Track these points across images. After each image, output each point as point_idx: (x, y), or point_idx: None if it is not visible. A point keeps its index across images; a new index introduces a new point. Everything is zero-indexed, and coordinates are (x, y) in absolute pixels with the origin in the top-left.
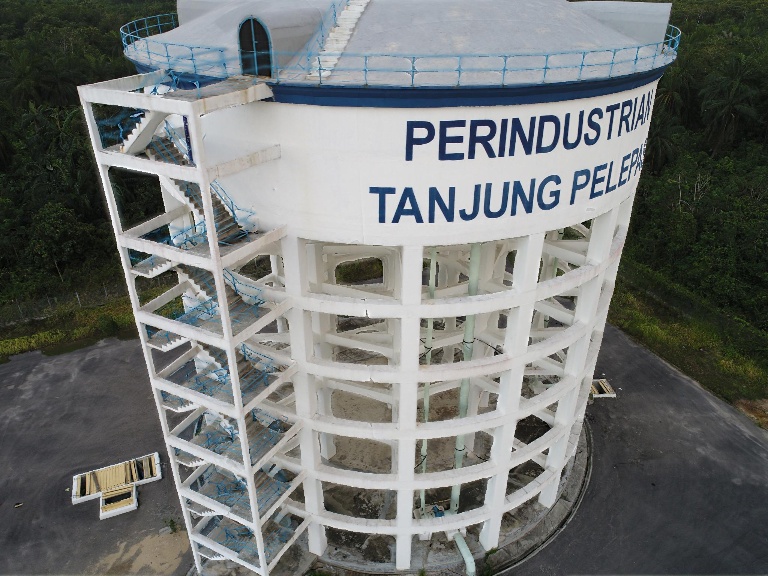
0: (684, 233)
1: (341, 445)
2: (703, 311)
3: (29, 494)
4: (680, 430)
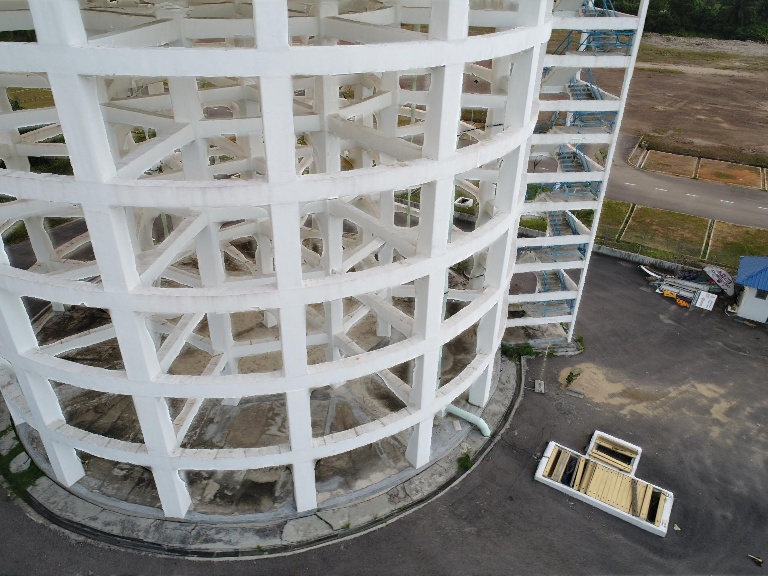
0: None
1: (364, 330)
2: None
3: (739, 568)
4: None
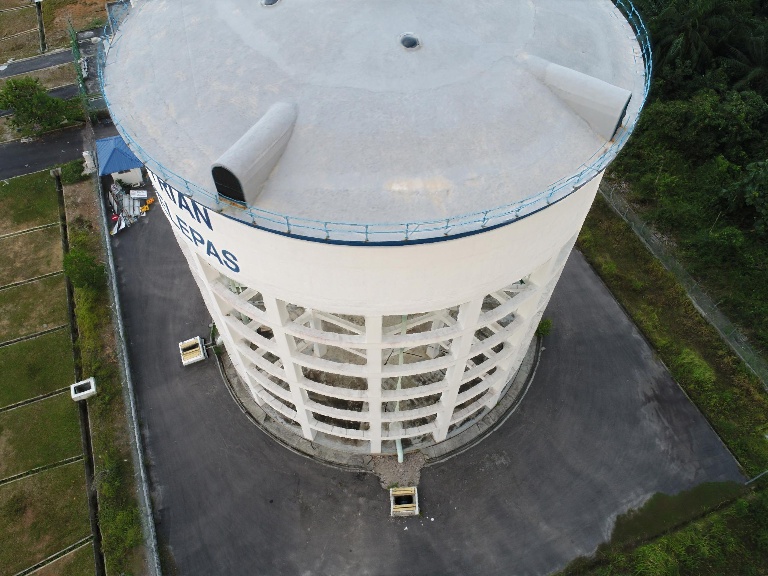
0: None
1: None
2: None
3: None
4: (337, 567)
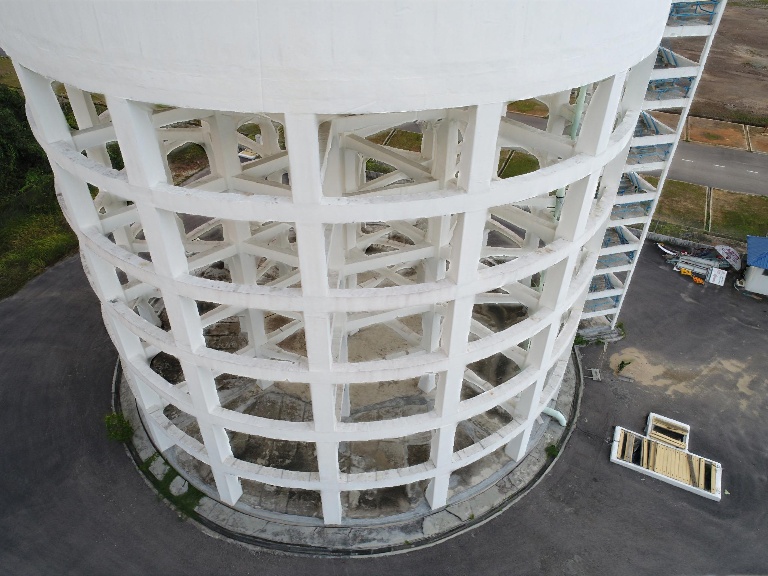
0: None
1: None
2: (1, 213)
3: None
4: None
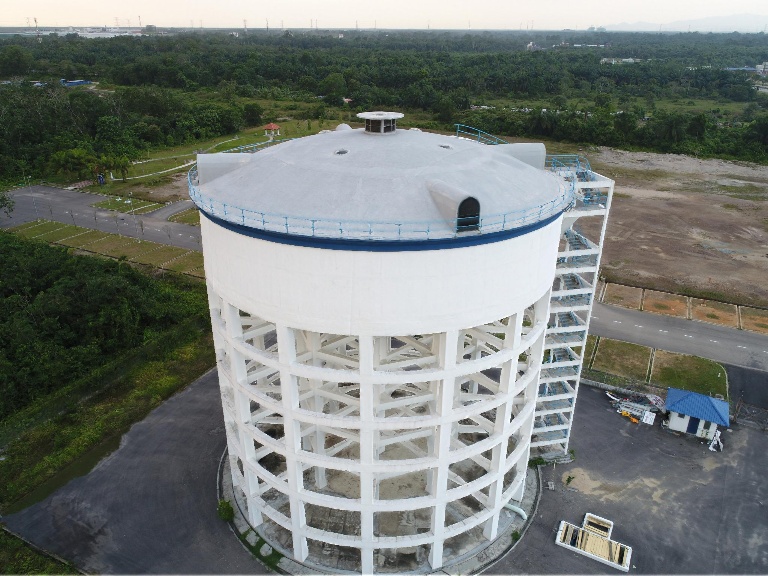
0: (6, 362)
1: None
2: None
3: None
4: None
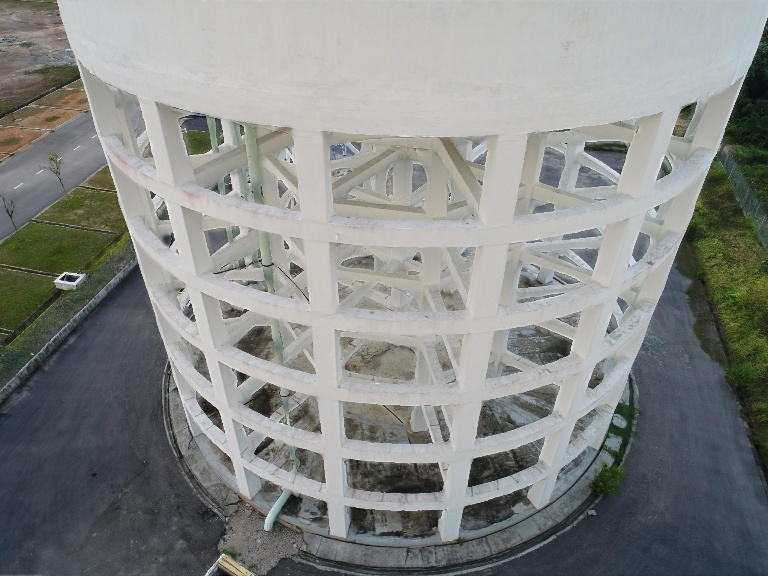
0: None
1: (381, 289)
2: None
3: None
4: None
